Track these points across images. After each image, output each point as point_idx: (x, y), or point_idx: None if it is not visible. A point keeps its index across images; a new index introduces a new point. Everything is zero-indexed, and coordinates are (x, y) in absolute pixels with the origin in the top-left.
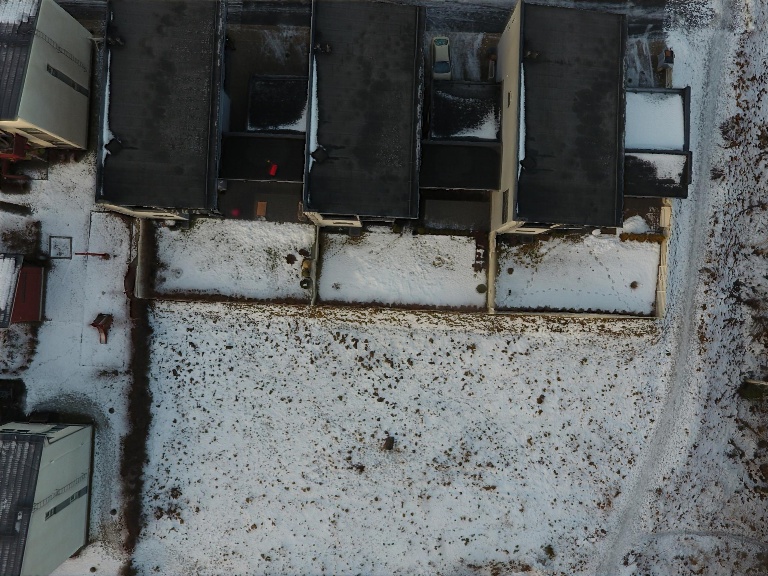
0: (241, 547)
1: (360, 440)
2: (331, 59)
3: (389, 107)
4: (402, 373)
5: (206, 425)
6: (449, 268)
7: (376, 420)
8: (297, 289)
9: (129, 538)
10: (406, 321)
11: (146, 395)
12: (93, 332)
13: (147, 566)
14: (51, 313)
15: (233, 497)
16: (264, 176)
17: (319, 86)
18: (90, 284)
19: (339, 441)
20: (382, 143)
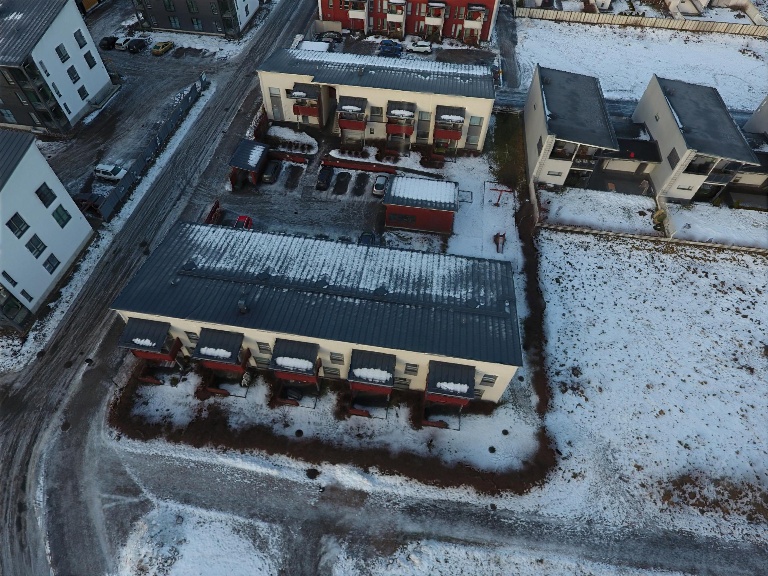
0: (654, 431)
1: (739, 346)
2: (674, 97)
3: (716, 118)
4: (755, 299)
5: (592, 321)
6: (766, 229)
7: (747, 332)
8: (652, 231)
9: (540, 404)
10: (744, 261)
11: (538, 291)
12: (490, 245)
13: (559, 438)
14: (458, 231)
15: (633, 382)
16: (626, 157)
17: (672, 105)
18: (486, 218)
19: (720, 345)
20: (720, 131)
